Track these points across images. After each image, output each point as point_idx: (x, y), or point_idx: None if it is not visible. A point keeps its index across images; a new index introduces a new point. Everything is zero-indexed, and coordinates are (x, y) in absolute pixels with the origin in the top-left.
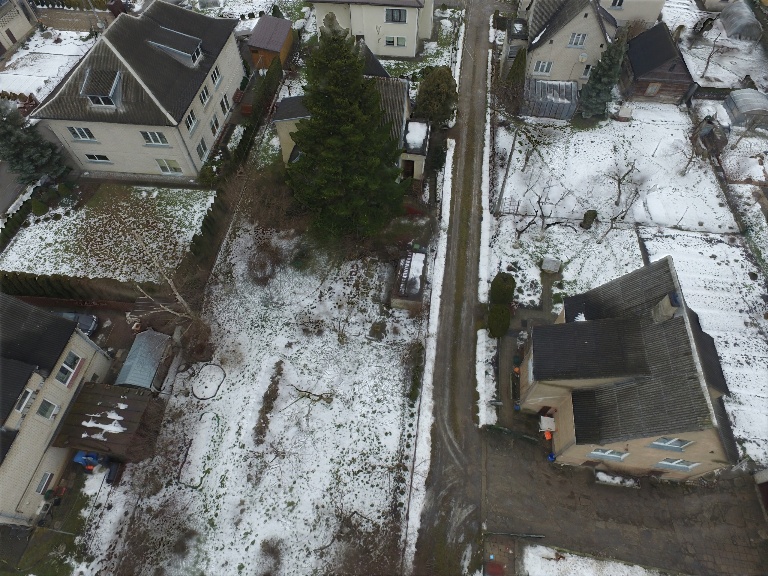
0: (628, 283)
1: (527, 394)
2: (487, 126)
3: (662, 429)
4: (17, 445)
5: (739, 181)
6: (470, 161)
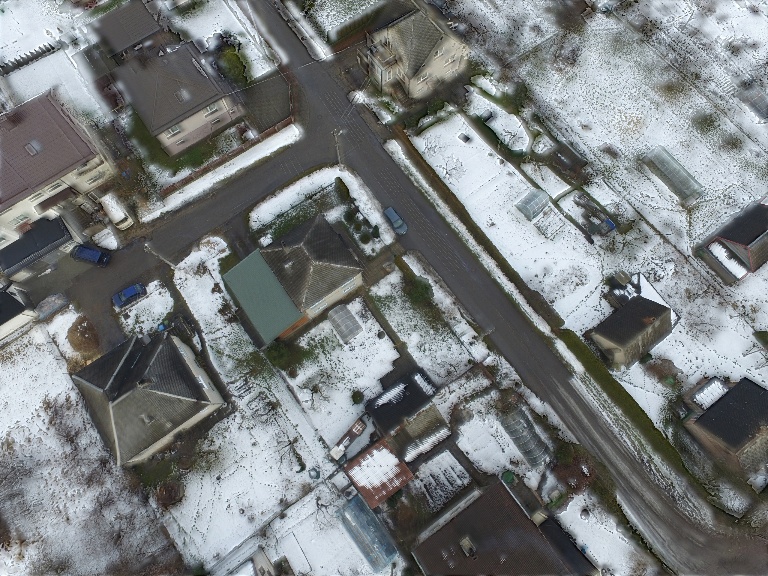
0: None
1: None
2: None
3: None
4: None
5: None
6: None
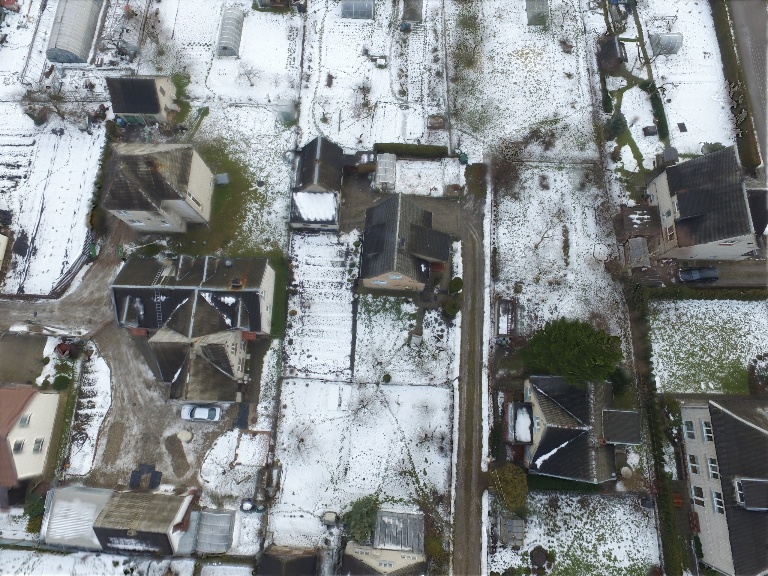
0: None
1: None
2: (454, 493)
3: None
4: None
5: (262, 433)
6: (468, 443)
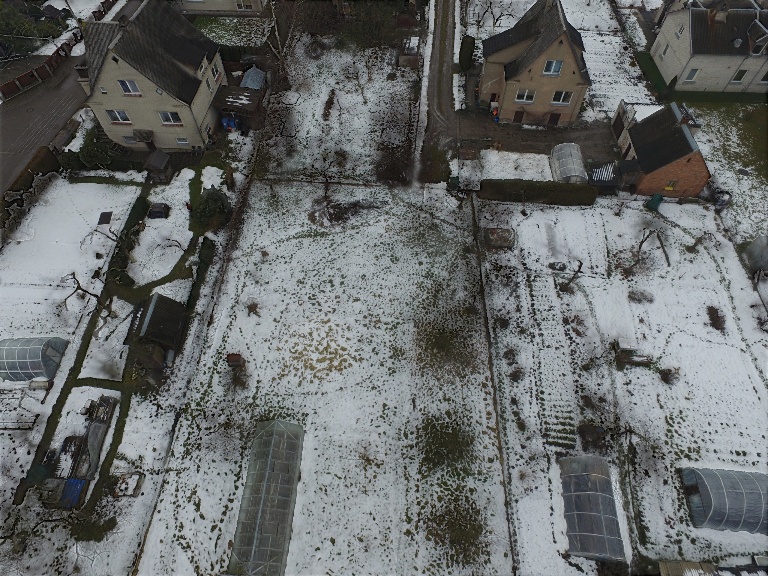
0: (534, 7)
1: (482, 85)
2: None
3: (544, 48)
4: (200, 91)
5: (625, 7)
6: (447, 1)
